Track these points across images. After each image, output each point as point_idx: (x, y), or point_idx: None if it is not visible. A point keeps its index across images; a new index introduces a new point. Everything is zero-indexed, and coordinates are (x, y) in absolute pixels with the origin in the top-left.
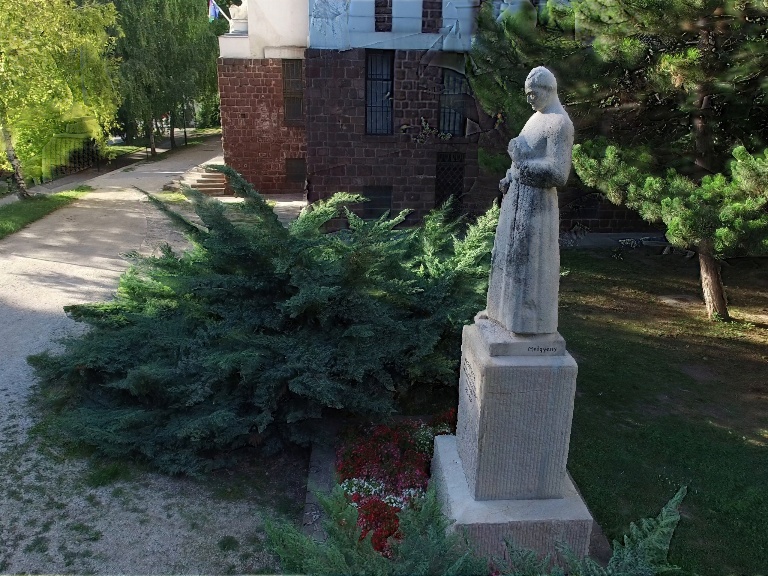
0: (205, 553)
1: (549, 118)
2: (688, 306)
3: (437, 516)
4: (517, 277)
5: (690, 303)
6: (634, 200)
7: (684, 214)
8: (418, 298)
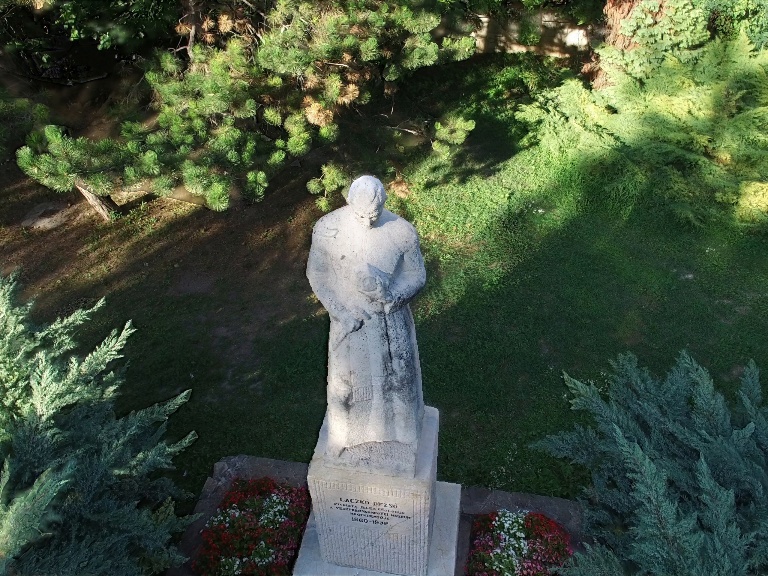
0: None
1: (392, 231)
2: (66, 217)
3: None
4: (413, 398)
5: (61, 212)
6: (136, 182)
7: (218, 177)
8: (8, 492)
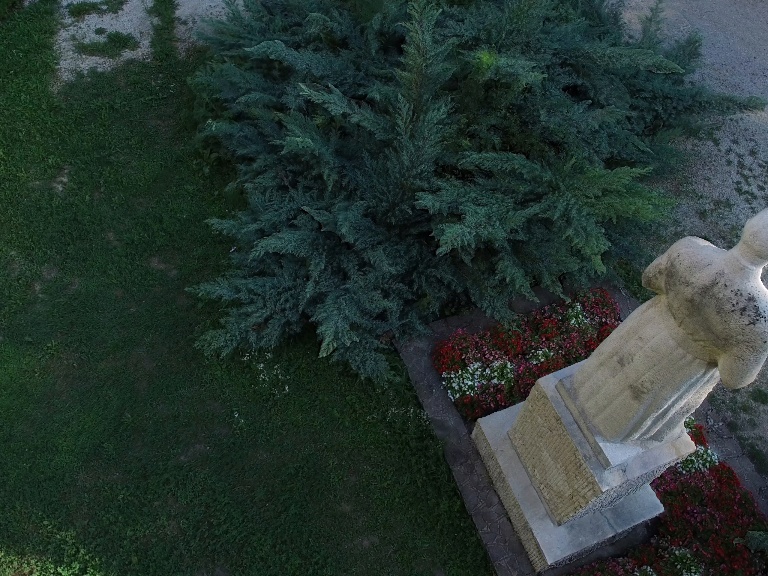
0: (767, 381)
1: None
2: None
3: (585, 245)
4: None
5: None
6: None
7: None
8: None
